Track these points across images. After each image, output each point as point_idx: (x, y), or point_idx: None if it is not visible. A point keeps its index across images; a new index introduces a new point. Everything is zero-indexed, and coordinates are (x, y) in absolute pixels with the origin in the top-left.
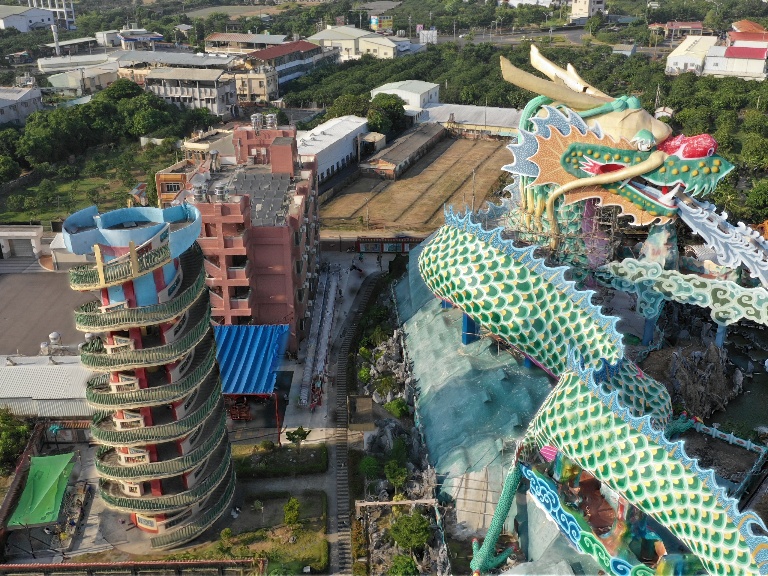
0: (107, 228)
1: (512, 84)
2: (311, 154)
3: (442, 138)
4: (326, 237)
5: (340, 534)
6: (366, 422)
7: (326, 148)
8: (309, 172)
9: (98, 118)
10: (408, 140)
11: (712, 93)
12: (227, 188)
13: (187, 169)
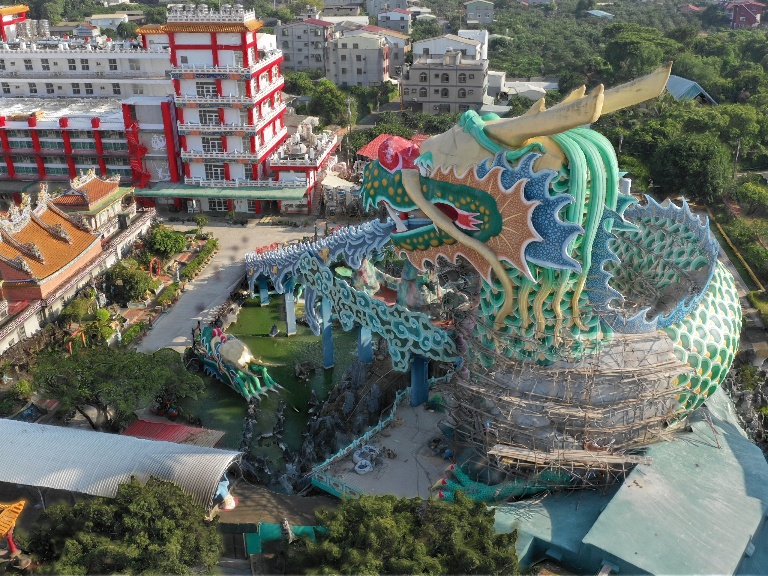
0: None
1: None
2: None
3: None
4: None
5: (747, 311)
6: (753, 332)
7: None
8: None
9: None
10: None
11: None
12: None
13: None
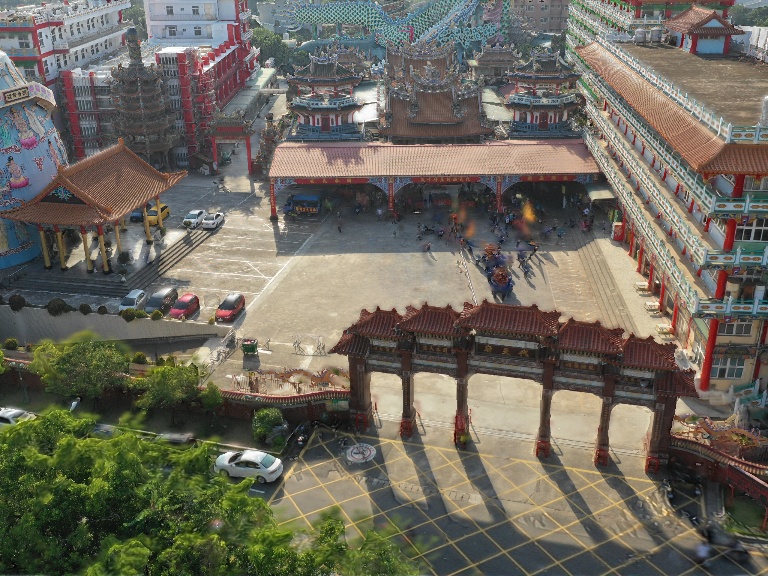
0: None
1: None
2: None
3: None
4: None
5: None
6: None
7: None
8: None
9: (758, 15)
10: None
11: None
12: None
13: None
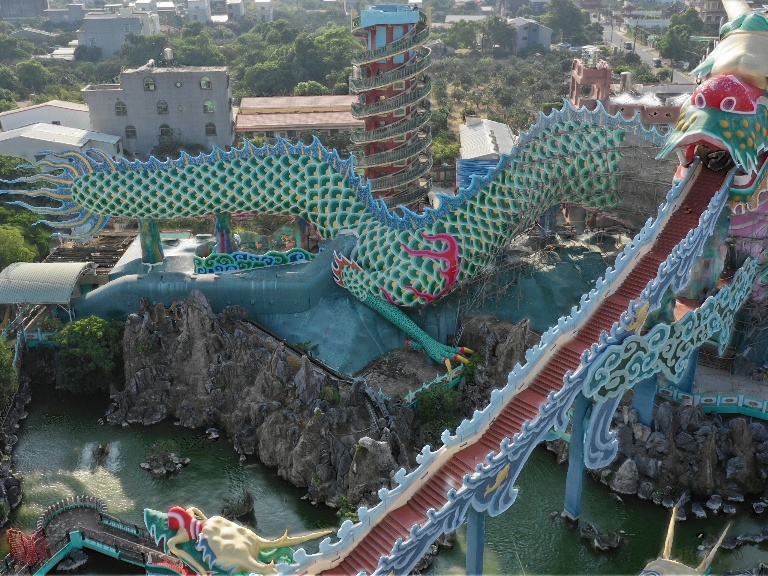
0: None
1: None
2: None
3: None
4: None
5: None
6: None
7: None
8: None
9: None
10: None
11: None
12: (591, 54)
13: None
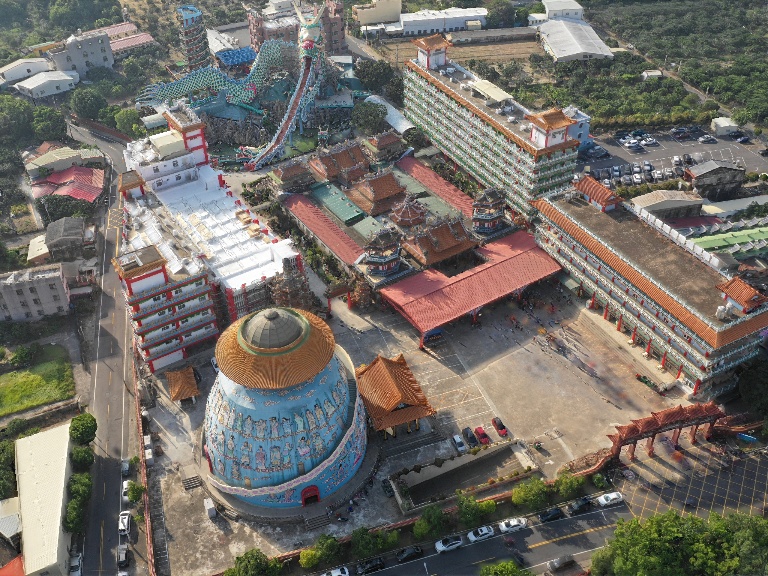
0: (190, 10)
1: (662, 25)
2: (415, 19)
3: (528, 38)
4: (366, 51)
5: None
6: None
7: (430, 19)
8: (321, 20)
9: None
10: (490, 31)
11: (735, 79)
12: None
13: (368, 8)
